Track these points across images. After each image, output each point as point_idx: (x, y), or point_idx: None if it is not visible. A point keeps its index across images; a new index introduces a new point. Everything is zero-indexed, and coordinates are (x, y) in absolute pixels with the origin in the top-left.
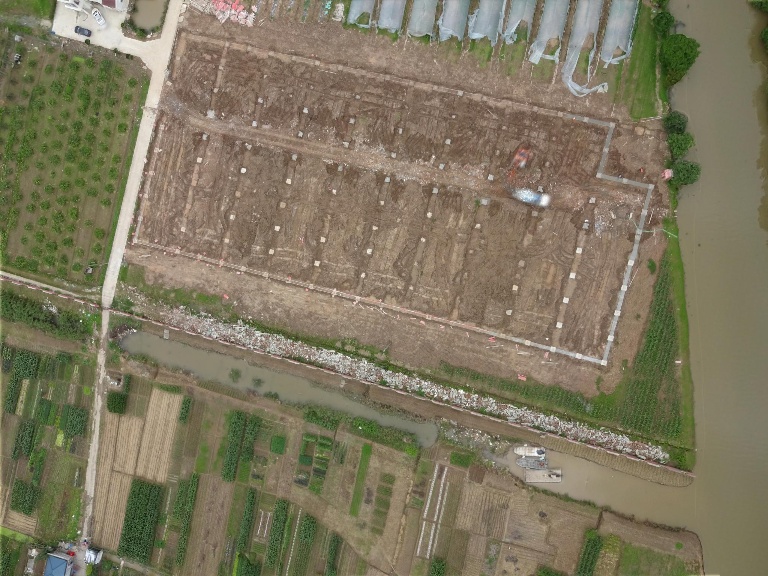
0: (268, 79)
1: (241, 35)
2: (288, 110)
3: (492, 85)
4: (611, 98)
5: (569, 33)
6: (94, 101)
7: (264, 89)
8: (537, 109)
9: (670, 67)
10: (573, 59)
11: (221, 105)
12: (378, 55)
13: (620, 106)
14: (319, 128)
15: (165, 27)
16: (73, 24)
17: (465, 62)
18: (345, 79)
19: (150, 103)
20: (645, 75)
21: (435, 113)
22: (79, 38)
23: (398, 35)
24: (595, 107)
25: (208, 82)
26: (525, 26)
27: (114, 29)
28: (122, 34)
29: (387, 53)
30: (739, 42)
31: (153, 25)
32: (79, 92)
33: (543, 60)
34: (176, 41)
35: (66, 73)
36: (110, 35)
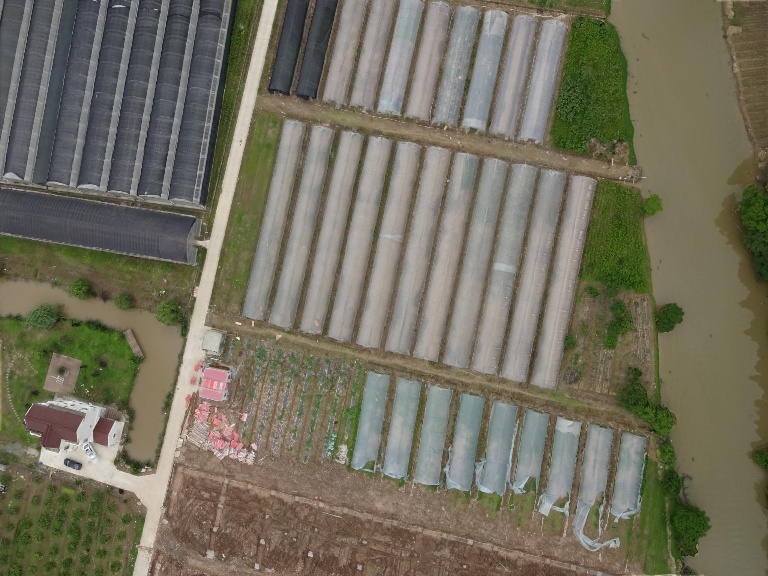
0: (270, 520)
1: (241, 473)
2: (292, 554)
3: (503, 535)
4: (624, 553)
5: (578, 486)
6: (85, 539)
7: (266, 530)
8: (549, 561)
9: (683, 541)
10: (583, 512)
11: (221, 546)
12: (384, 500)
13: (633, 562)
14: (325, 574)
15: (160, 462)
16: (62, 454)
17: (474, 511)
18: (351, 524)
19: (145, 542)
20: (656, 531)
21: (445, 564)
22: (69, 469)
23: (404, 481)
24: (608, 562)
25: (207, 521)
26: (533, 477)
27: (106, 462)
28: (115, 467)
29: (393, 498)
30: (745, 488)
31: (148, 458)
32: (69, 528)
33: (553, 511)
34: (172, 476)
35: (54, 505)
36: (102, 468)
